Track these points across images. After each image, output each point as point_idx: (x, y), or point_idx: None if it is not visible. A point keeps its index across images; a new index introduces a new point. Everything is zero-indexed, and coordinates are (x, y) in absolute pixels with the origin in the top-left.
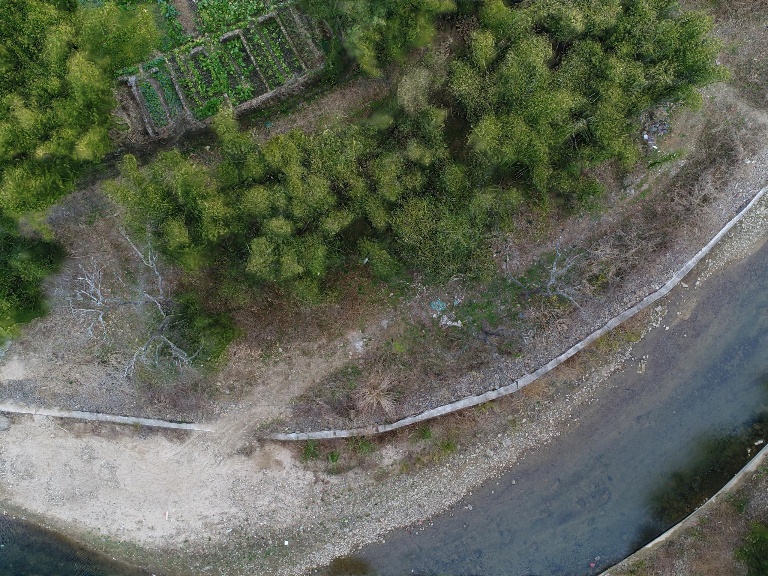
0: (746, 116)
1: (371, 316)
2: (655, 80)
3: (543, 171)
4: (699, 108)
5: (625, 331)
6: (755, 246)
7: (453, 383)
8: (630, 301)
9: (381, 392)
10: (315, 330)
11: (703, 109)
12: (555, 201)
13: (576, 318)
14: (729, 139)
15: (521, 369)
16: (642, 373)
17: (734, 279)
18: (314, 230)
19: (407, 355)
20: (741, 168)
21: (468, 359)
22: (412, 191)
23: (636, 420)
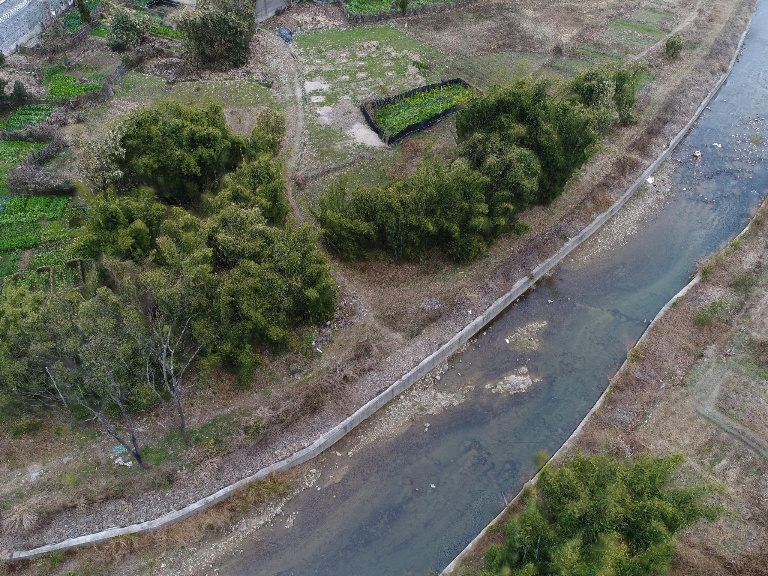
0: (386, 335)
1: (57, 453)
2: (292, 287)
3: (203, 329)
4: (354, 330)
5: (273, 480)
6: (401, 429)
7: (101, 512)
8: (281, 455)
9: (28, 508)
10: (1, 456)
11: (357, 330)
12: (238, 380)
13: (228, 461)
14: (369, 345)
15: (169, 505)
16: (289, 528)
17: (383, 453)
18: (23, 355)
19: (72, 486)
20: (373, 360)
21: (119, 485)
22: (103, 332)
23: (276, 575)
